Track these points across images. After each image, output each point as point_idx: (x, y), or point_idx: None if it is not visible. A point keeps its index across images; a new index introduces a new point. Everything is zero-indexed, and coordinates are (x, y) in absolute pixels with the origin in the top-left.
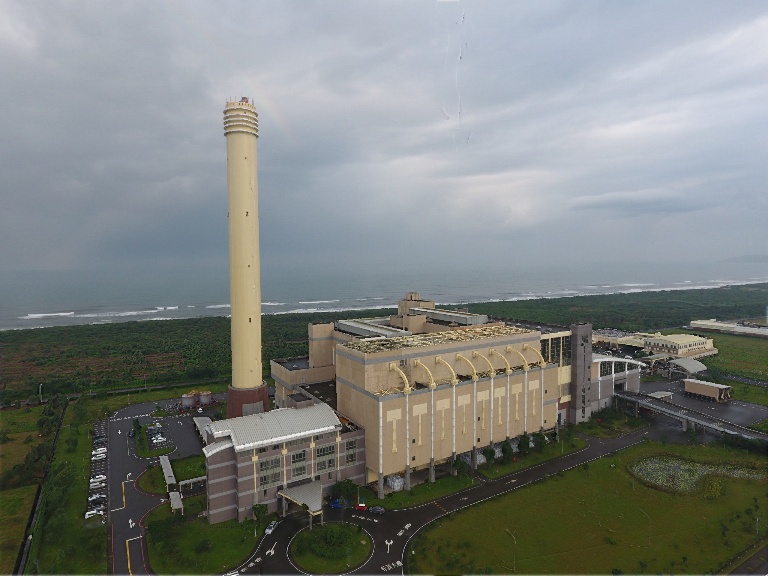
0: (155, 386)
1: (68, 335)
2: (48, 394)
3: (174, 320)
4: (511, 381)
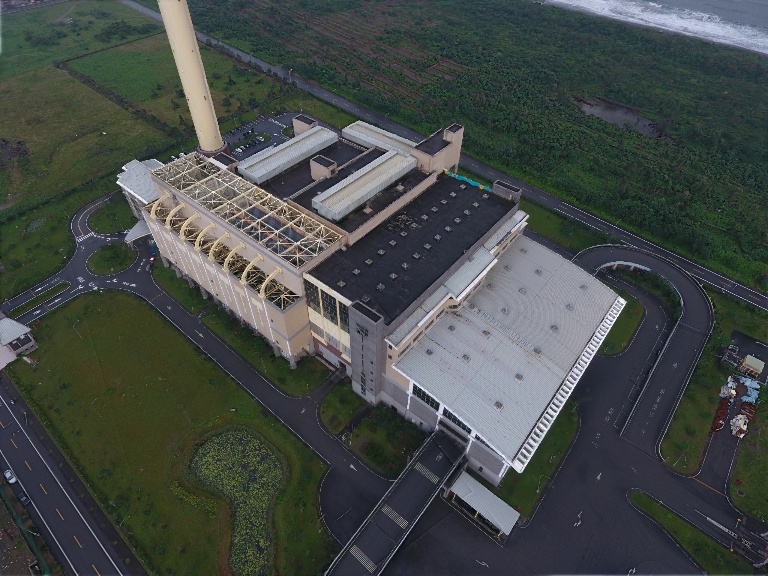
0: (350, 102)
1: (463, 6)
2: (306, 77)
3: (571, 14)
4: (232, 280)
